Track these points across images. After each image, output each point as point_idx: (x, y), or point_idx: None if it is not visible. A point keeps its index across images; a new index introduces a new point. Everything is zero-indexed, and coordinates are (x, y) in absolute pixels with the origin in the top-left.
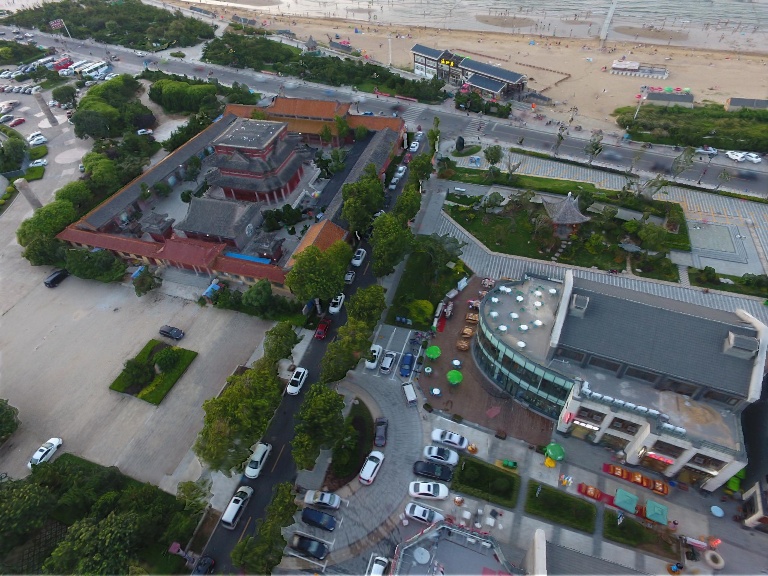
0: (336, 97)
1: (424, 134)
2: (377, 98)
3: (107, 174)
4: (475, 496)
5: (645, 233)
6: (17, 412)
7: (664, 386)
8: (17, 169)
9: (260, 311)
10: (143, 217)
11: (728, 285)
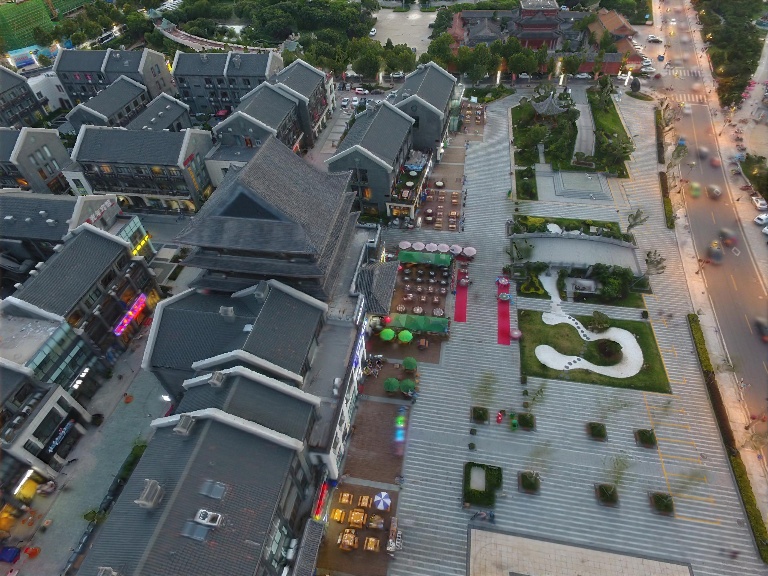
0: (683, 45)
1: (650, 78)
2: (699, 57)
3: (504, 6)
4: None
5: None
6: (366, 35)
7: None
8: None
9: None
10: None
11: None
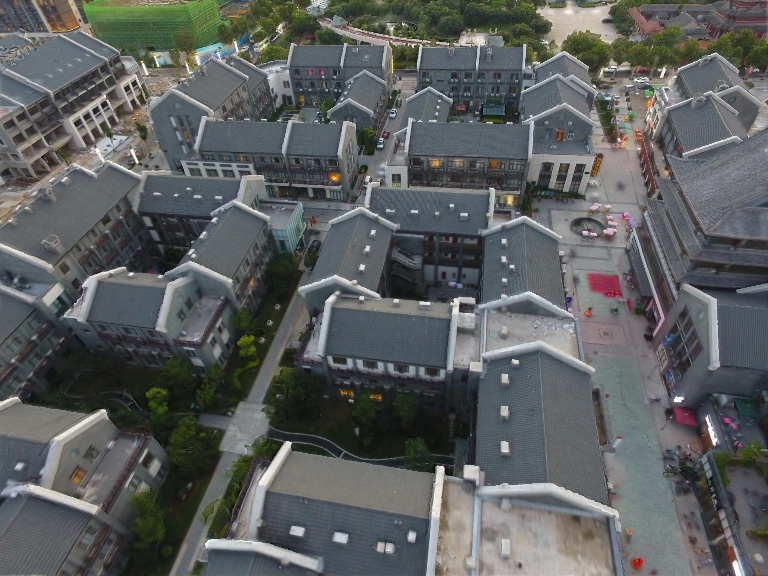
0: None
1: None
2: None
3: (680, 0)
4: (596, 105)
5: None
6: (550, 30)
7: None
8: None
9: None
10: None
11: None
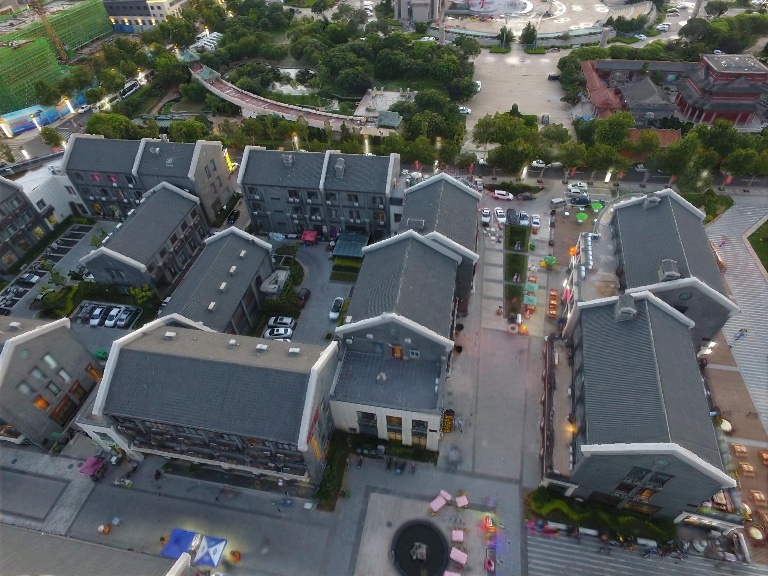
0: None
1: None
2: None
3: (647, 52)
4: (506, 233)
5: None
6: None
7: (619, 271)
8: (626, 32)
9: (580, 138)
10: (627, 83)
11: None
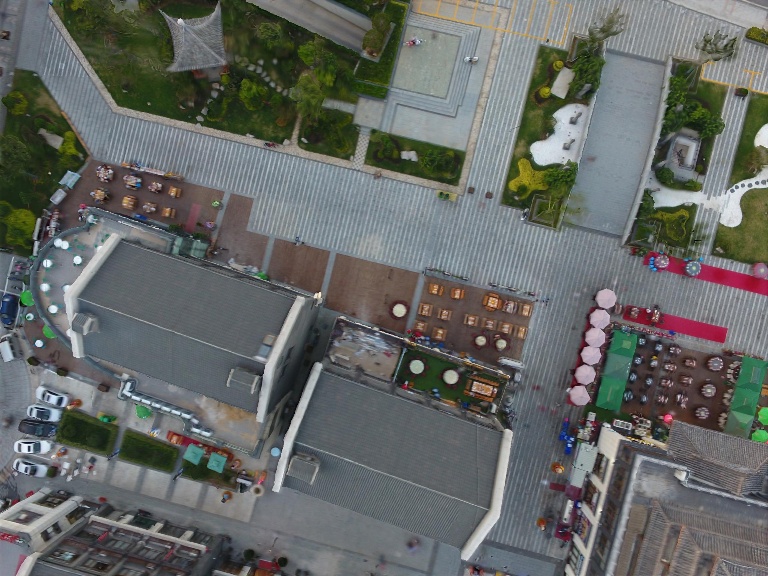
0: None
1: None
2: None
3: None
4: (76, 447)
5: (294, 97)
6: None
7: None
8: None
9: None
10: None
11: (410, 163)
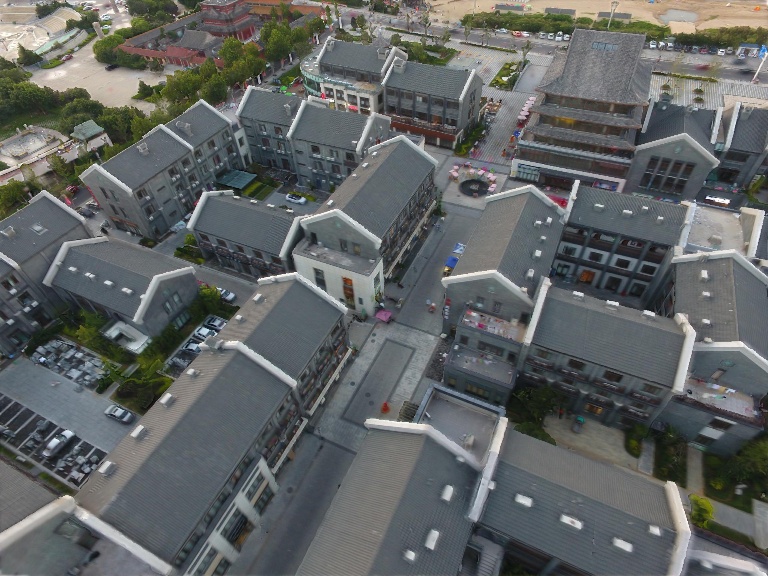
0: (297, 4)
1: None
2: (322, 5)
3: (143, 26)
4: None
5: None
6: (90, 96)
7: (359, 78)
8: None
9: None
10: None
11: None
